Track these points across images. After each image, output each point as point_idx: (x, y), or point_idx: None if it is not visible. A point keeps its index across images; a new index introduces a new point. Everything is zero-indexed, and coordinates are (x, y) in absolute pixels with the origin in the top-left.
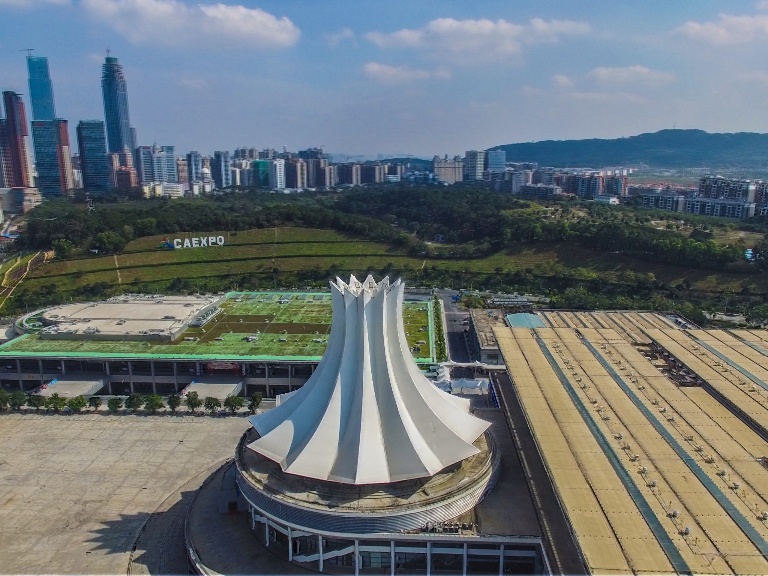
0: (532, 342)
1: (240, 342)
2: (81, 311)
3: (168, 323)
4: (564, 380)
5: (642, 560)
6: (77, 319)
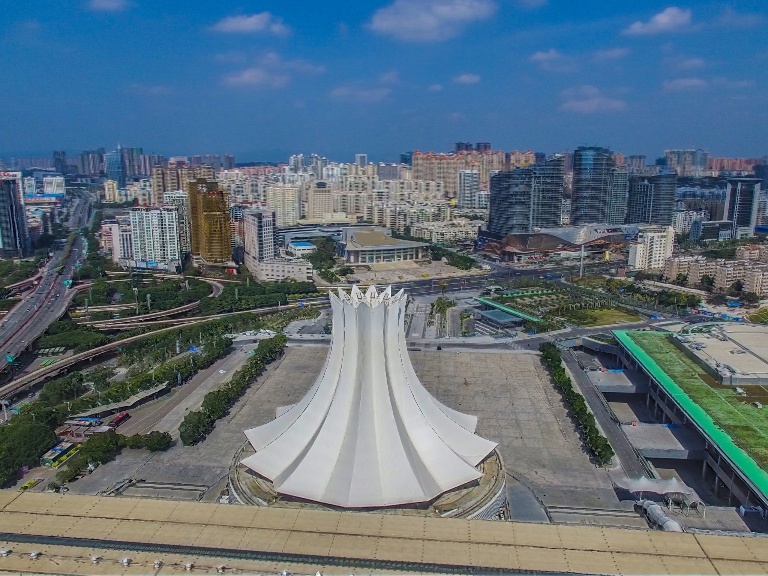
0: (689, 574)
1: (763, 417)
2: (754, 333)
3: (766, 370)
4: (458, 570)
5: (5, 518)
6: (723, 336)
